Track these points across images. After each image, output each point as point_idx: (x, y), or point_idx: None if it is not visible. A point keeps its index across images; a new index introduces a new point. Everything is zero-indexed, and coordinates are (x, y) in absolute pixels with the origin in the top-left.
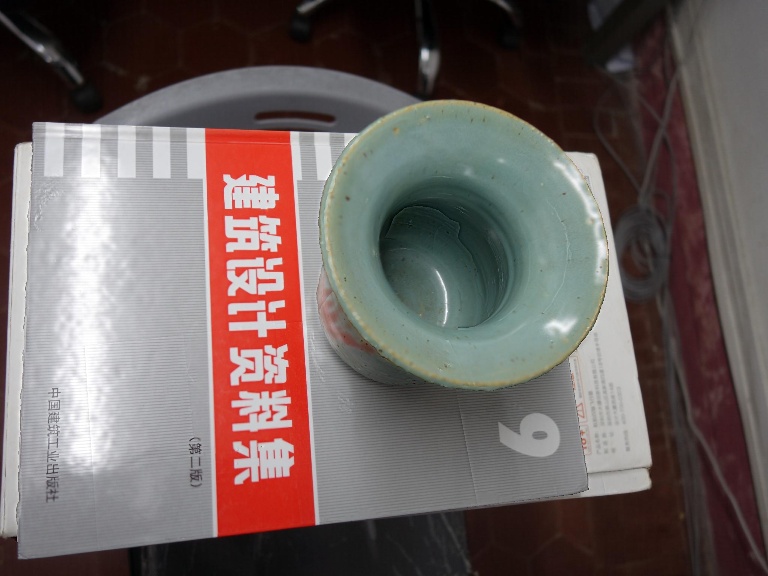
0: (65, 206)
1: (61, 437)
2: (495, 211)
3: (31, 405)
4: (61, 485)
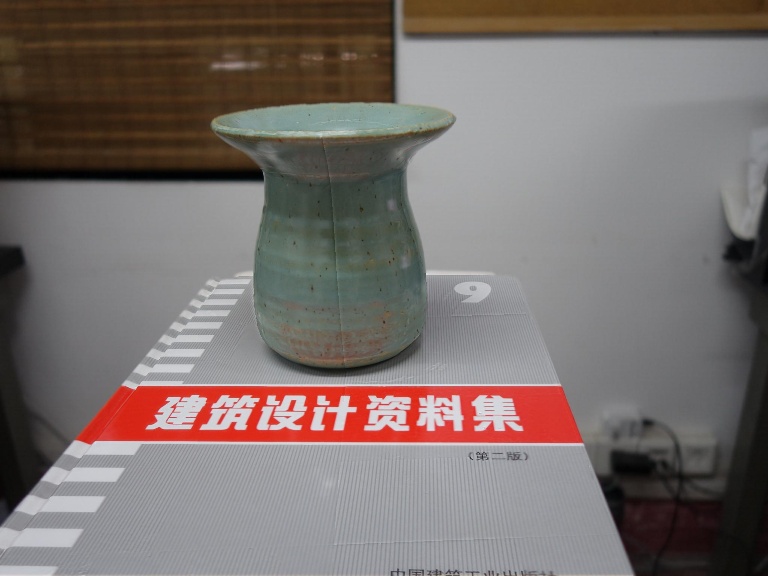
0: (108, 564)
1: (464, 568)
2: None
3: None
4: (533, 569)
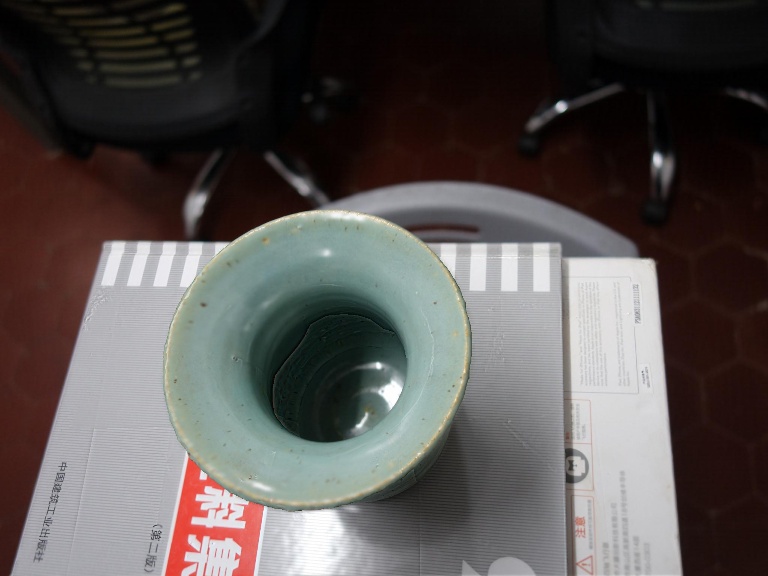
0: (109, 310)
1: (58, 506)
2: (391, 321)
3: (44, 475)
4: (47, 549)
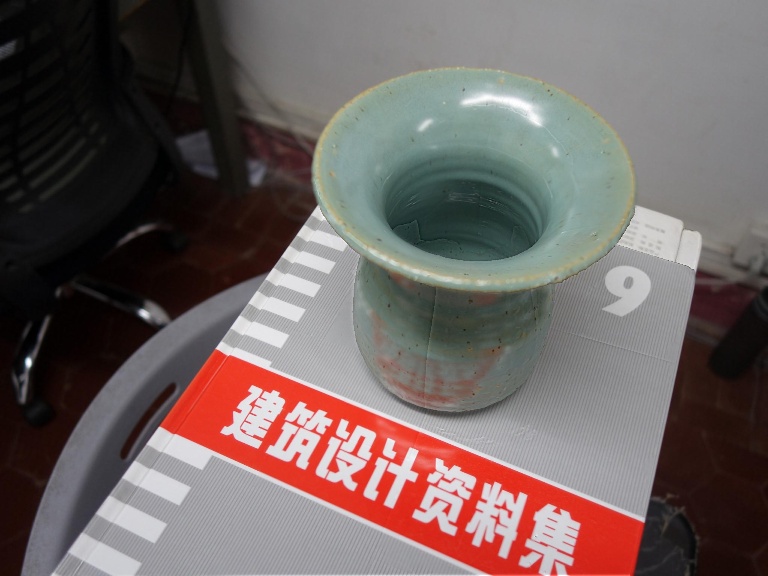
0: None
1: None
2: (438, 163)
3: None
4: None
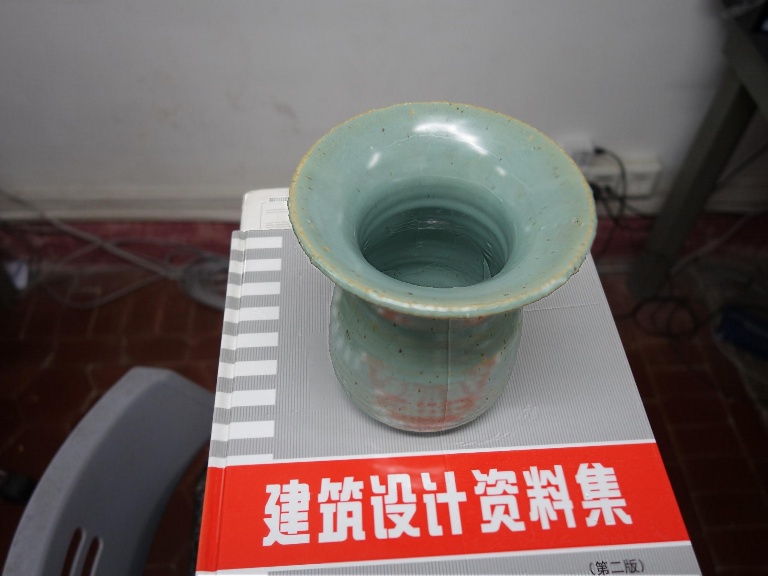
0: None
1: None
2: (382, 204)
3: None
4: None
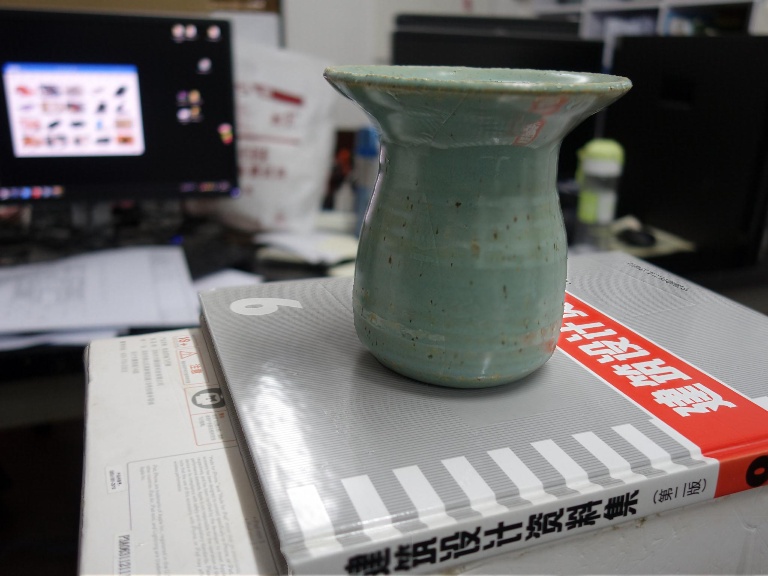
0: None
1: None
2: None
3: None
4: None
